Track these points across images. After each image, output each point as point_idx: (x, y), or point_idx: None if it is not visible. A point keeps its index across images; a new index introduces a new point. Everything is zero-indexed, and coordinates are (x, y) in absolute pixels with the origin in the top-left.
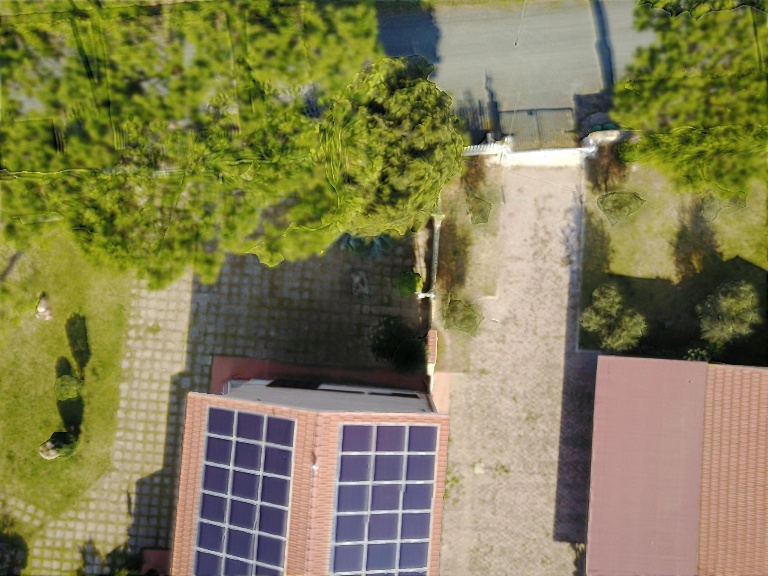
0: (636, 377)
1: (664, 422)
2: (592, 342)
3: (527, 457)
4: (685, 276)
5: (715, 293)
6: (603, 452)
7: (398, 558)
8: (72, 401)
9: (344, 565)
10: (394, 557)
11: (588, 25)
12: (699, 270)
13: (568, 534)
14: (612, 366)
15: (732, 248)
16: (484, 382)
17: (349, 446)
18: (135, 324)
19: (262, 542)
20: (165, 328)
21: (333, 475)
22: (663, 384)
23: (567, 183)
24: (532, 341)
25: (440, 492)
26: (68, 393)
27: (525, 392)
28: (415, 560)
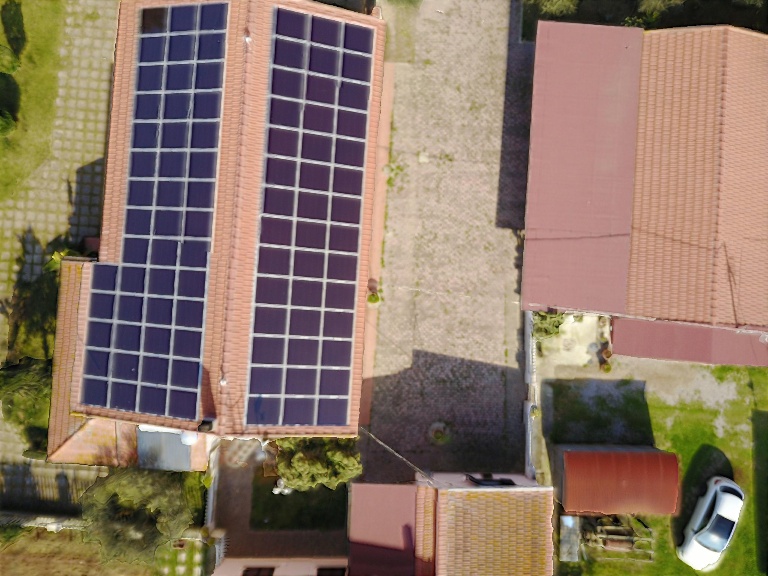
0: (575, 42)
1: (601, 87)
2: (535, 33)
3: (471, 146)
4: None
5: None
6: (542, 115)
7: (334, 152)
8: (9, 90)
9: (279, 147)
10: (330, 150)
11: None
12: None
13: (510, 221)
14: (552, 31)
15: None
16: (429, 72)
17: (284, 29)
18: (74, 12)
19: (196, 129)
20: (105, 16)
21: (267, 56)
22: (601, 49)
23: None
24: (476, 33)
25: (377, 96)
26: (3, 64)
27: (469, 82)
28: (351, 159)
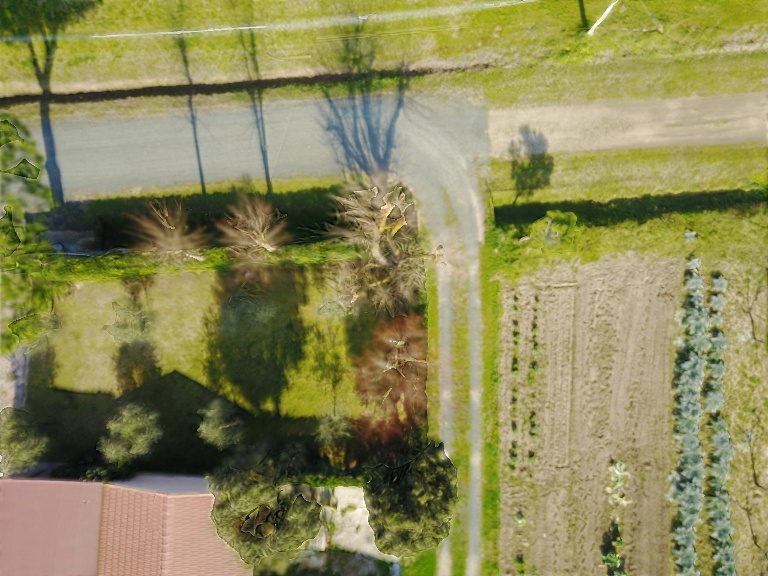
0: (31, 499)
1: (59, 542)
2: None
3: None
4: (126, 390)
5: (112, 416)
6: None
7: None
8: None
9: None
10: None
11: (39, 145)
12: (139, 384)
13: None
14: (8, 489)
15: (170, 363)
16: None
17: None
18: None
19: None
20: None
21: None
22: (58, 505)
23: (15, 300)
24: None
25: None
26: None
27: None
28: None
